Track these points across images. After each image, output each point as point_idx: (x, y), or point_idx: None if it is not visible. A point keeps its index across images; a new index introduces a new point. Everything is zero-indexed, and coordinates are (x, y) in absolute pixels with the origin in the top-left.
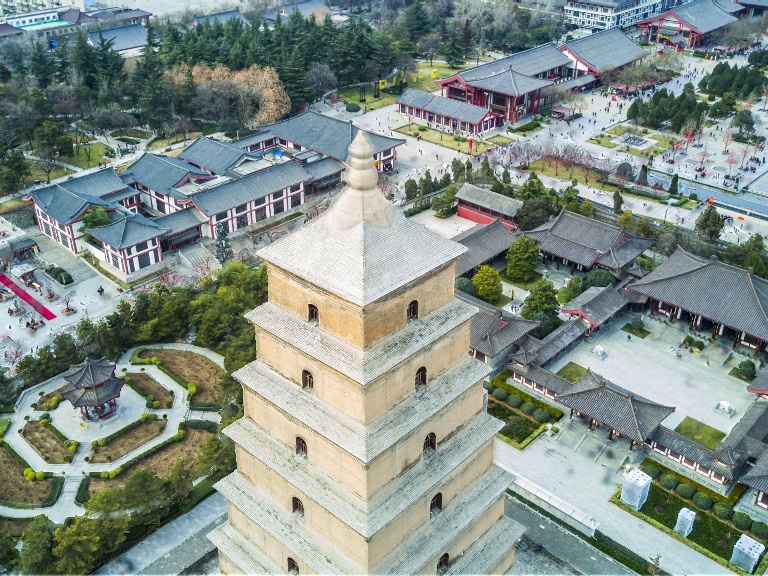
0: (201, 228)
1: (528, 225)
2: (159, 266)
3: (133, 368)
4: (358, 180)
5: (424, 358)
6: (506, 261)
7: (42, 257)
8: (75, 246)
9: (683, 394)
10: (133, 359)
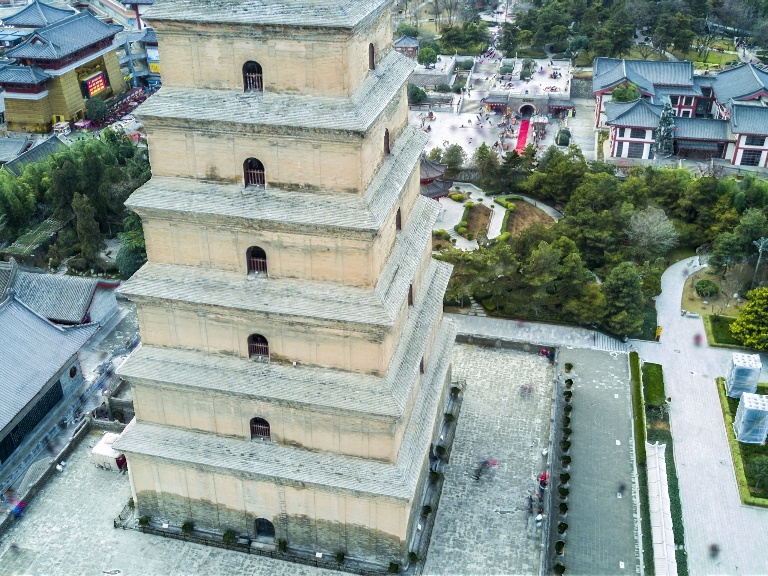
0: (727, 147)
1: None
2: (649, 163)
3: (491, 203)
4: None
5: (257, 49)
6: None
7: (569, 120)
8: (599, 120)
9: None
10: (500, 198)
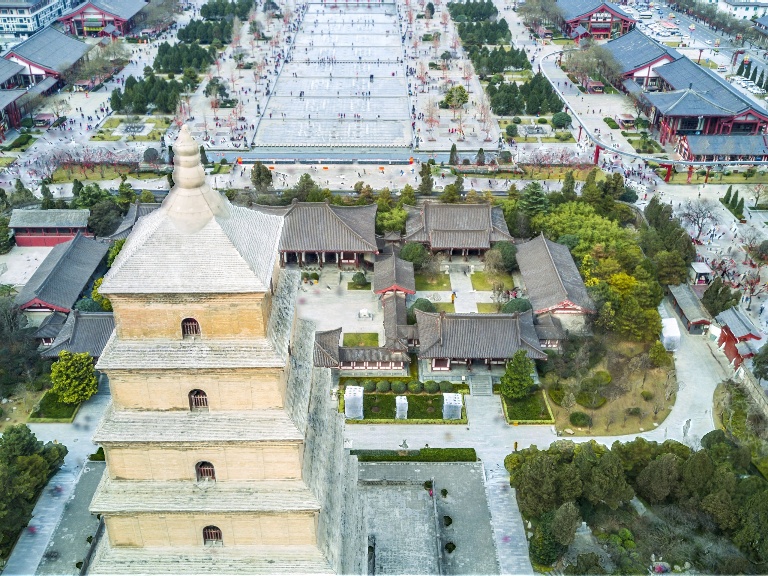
0: None
1: (106, 230)
2: None
3: None
4: (195, 177)
5: None
6: (104, 271)
7: None
8: None
9: (329, 318)
10: None
